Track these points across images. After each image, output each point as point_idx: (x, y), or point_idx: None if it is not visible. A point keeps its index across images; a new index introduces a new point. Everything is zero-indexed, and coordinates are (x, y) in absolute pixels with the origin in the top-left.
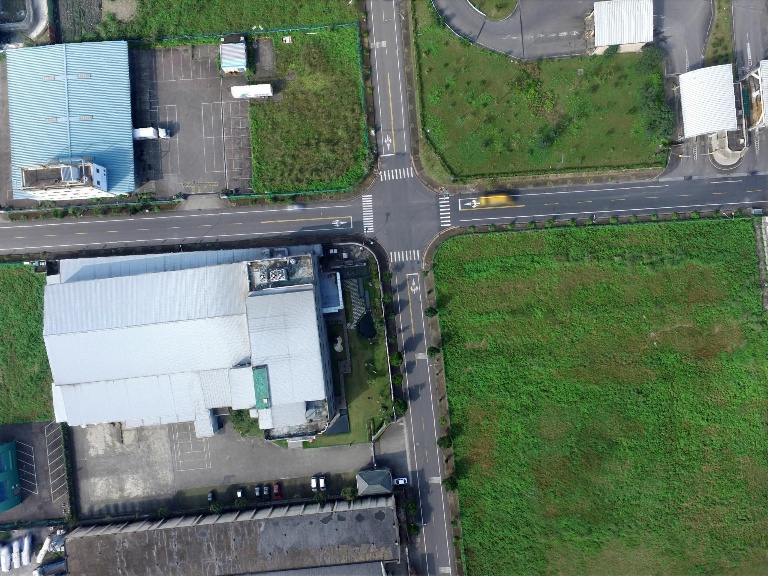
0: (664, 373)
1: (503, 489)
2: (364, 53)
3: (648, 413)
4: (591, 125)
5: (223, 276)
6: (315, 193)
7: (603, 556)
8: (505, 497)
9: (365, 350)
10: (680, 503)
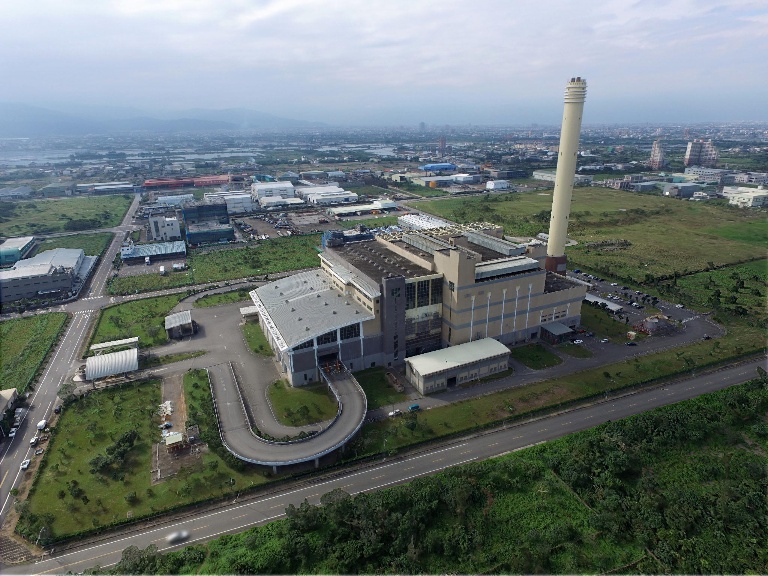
0: None
1: None
2: None
3: None
4: None
5: None
6: None
7: None
8: None
9: None
10: None
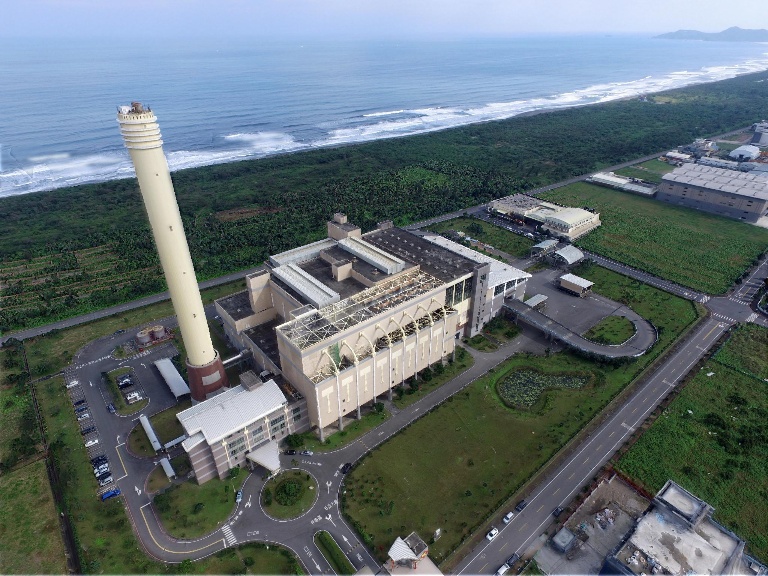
0: None
1: None
2: (714, 351)
3: None
4: None
5: None
6: None
7: None
8: None
9: None
10: None
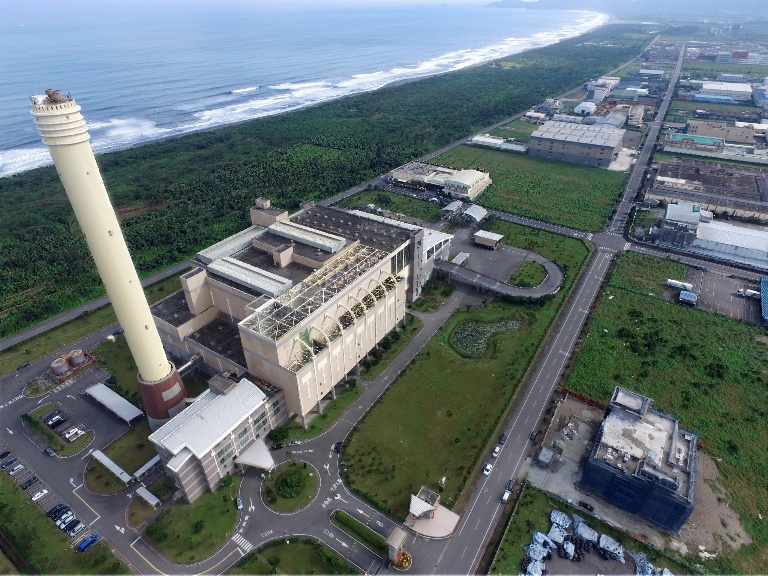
0: None
1: None
2: None
3: None
4: None
5: None
6: None
7: None
8: None
9: None
10: None
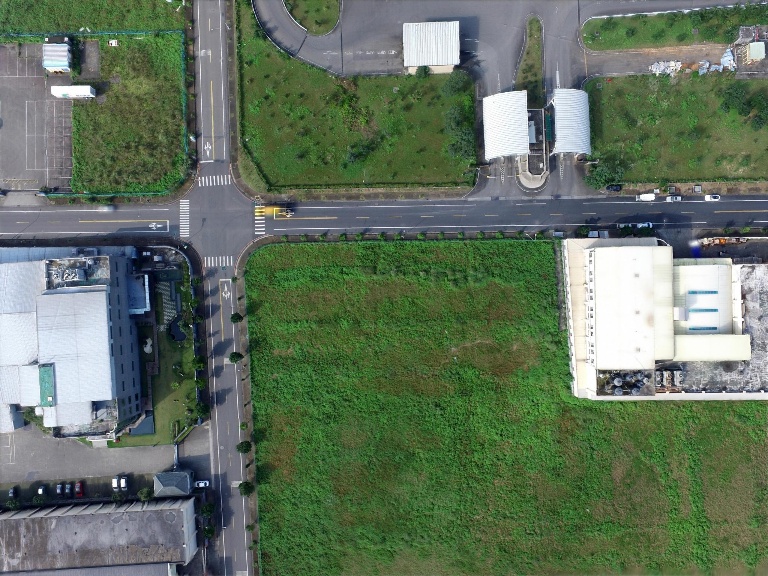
0: (462, 387)
1: (302, 495)
2: (188, 60)
3: (445, 426)
4: (404, 142)
5: (24, 273)
6: (133, 195)
7: (396, 565)
8: (303, 503)
9: (174, 353)
10: (472, 515)
